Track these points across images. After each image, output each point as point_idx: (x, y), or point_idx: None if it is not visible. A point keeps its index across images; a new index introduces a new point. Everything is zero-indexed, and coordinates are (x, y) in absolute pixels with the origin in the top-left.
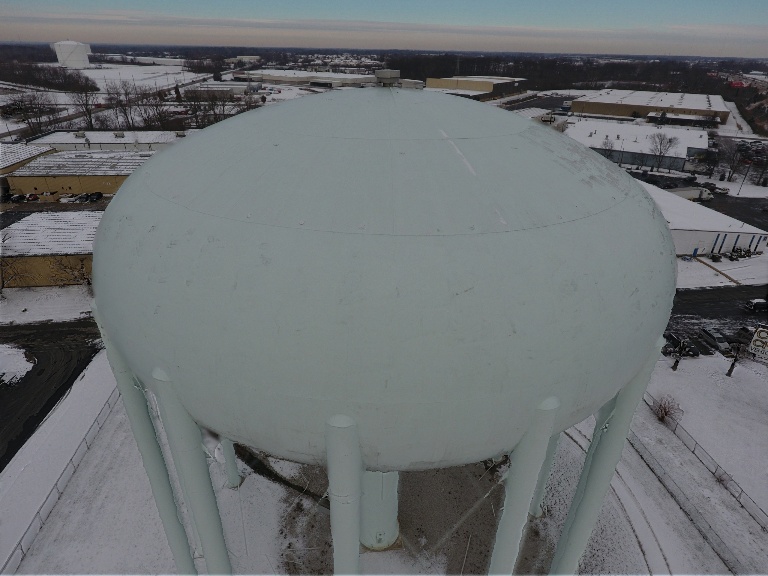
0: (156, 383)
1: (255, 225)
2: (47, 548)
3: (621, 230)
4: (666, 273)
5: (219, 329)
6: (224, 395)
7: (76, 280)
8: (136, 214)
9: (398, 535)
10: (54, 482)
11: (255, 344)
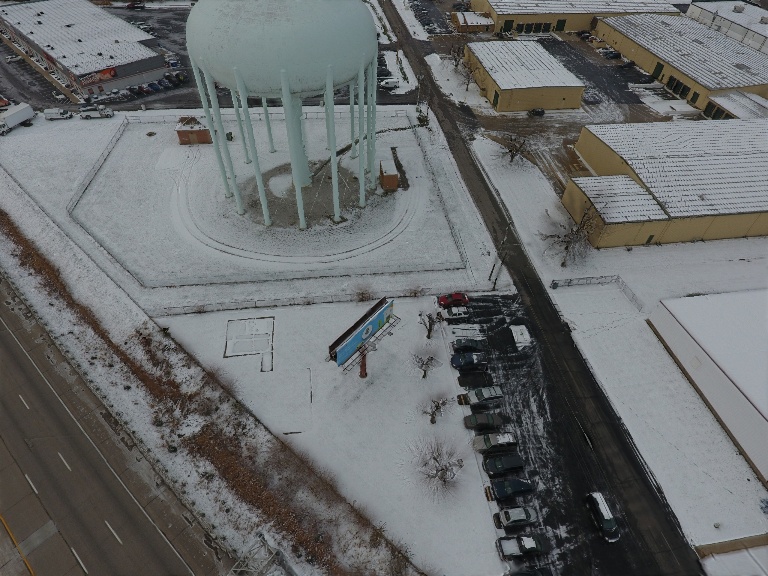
0: None
1: None
2: (308, 121)
3: (204, 21)
4: (205, 41)
5: None
6: None
7: None
8: None
9: None
10: None
11: None
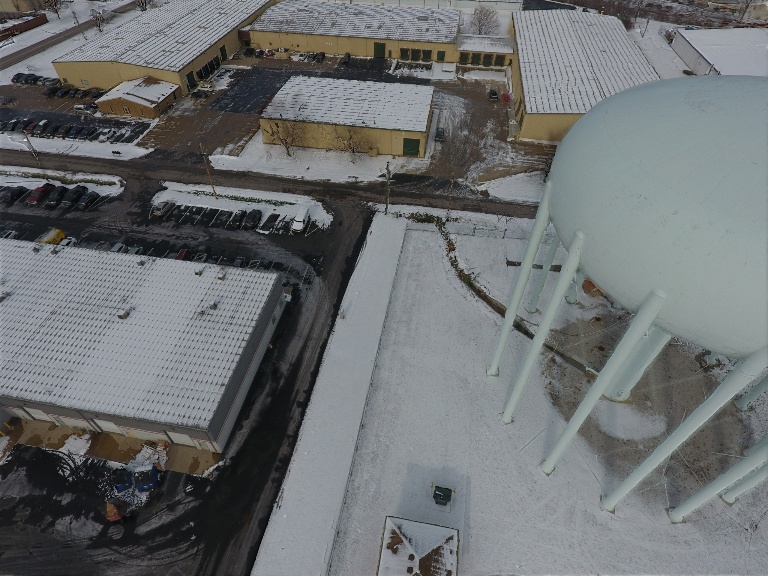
0: (653, 297)
1: (761, 229)
2: (392, 346)
3: None
4: None
5: (724, 283)
6: (704, 313)
7: (347, 149)
8: (653, 197)
9: (630, 395)
10: (380, 306)
11: (747, 295)
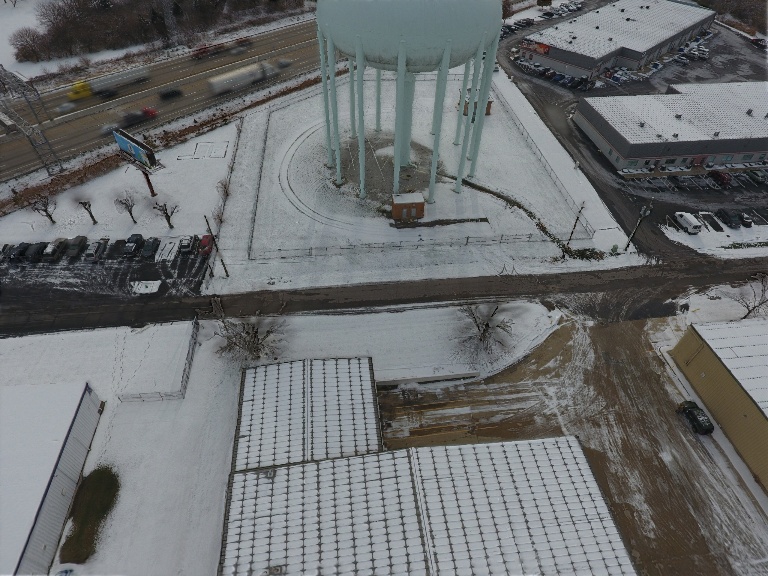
0: None
1: None
2: None
3: None
4: None
5: None
6: None
7: None
8: None
9: None
10: None
11: None
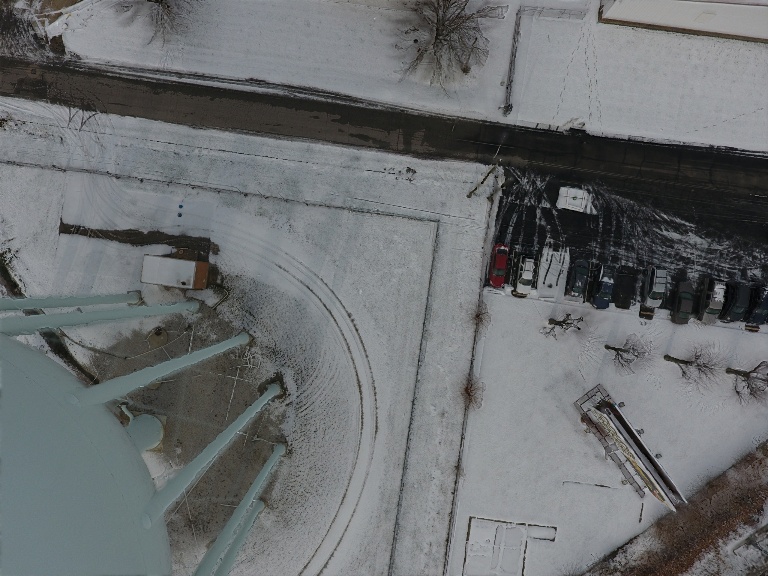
0: None
1: None
2: None
3: None
4: None
5: None
6: None
7: None
8: None
9: (160, 442)
10: None
11: None
